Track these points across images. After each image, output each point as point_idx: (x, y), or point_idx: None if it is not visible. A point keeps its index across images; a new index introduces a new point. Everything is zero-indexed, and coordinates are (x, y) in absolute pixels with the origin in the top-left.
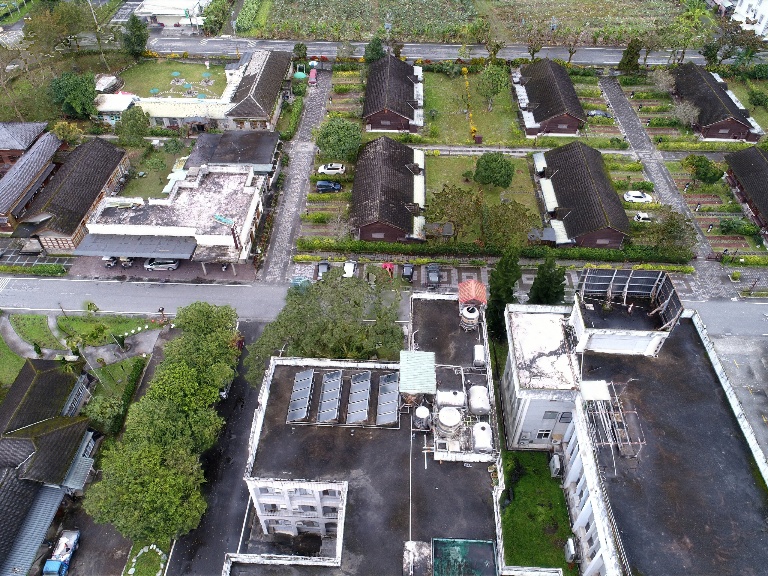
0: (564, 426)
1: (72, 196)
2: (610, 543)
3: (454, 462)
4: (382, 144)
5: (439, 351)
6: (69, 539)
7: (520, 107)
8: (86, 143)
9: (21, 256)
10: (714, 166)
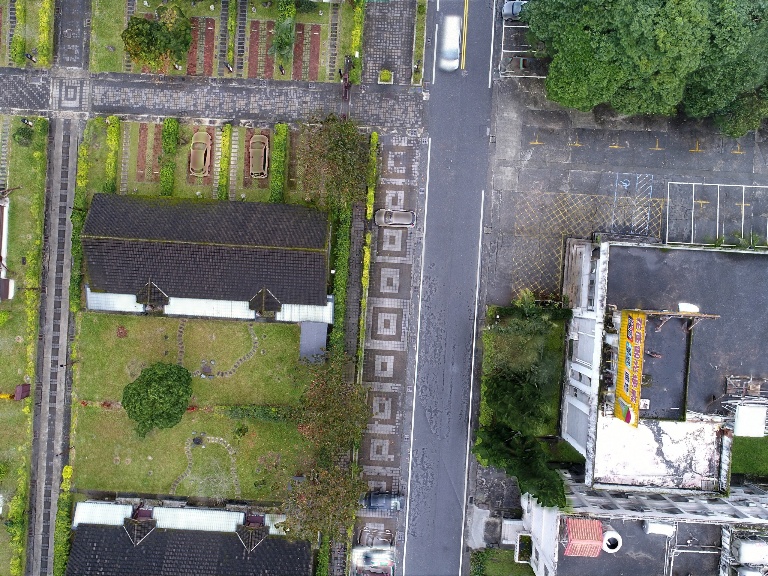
0: None
1: None
2: None
3: None
4: None
5: (642, 572)
6: None
7: None
8: None
9: None
10: (173, 23)
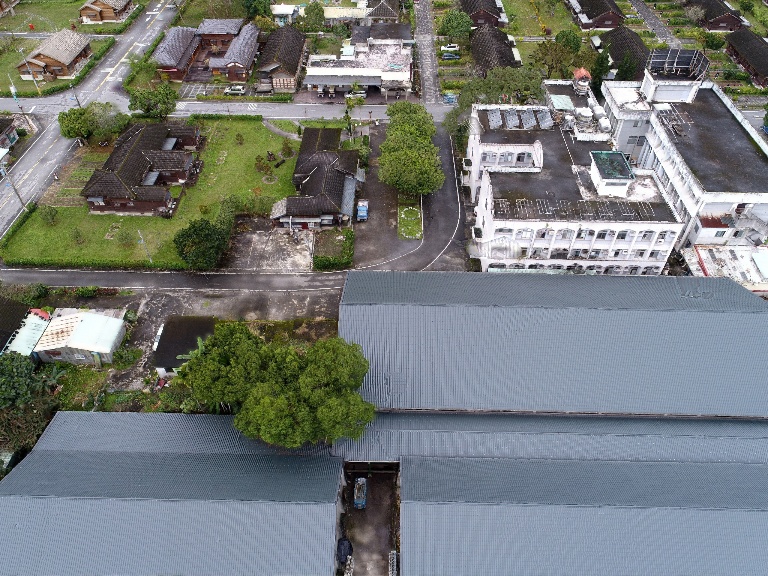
0: (639, 149)
1: (287, 55)
2: (678, 159)
3: (588, 141)
4: (488, 27)
5: None
6: (363, 203)
7: (575, 13)
8: (280, 29)
9: (257, 93)
10: (718, 36)
